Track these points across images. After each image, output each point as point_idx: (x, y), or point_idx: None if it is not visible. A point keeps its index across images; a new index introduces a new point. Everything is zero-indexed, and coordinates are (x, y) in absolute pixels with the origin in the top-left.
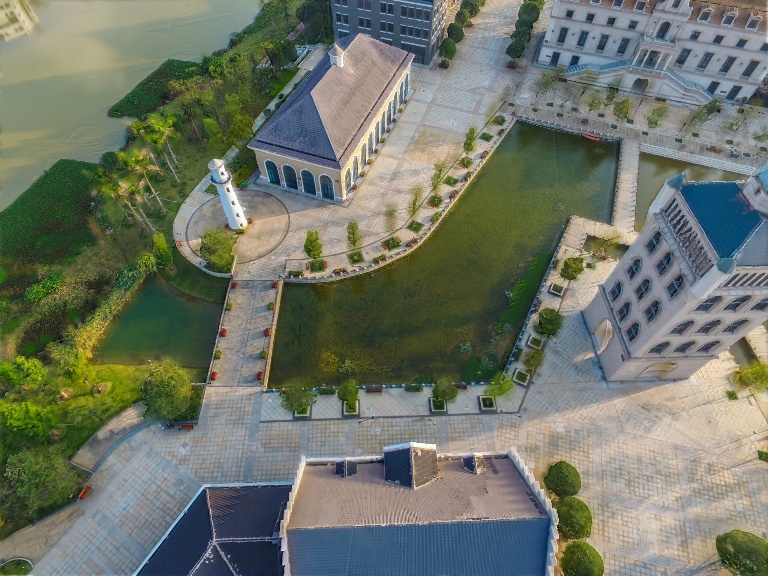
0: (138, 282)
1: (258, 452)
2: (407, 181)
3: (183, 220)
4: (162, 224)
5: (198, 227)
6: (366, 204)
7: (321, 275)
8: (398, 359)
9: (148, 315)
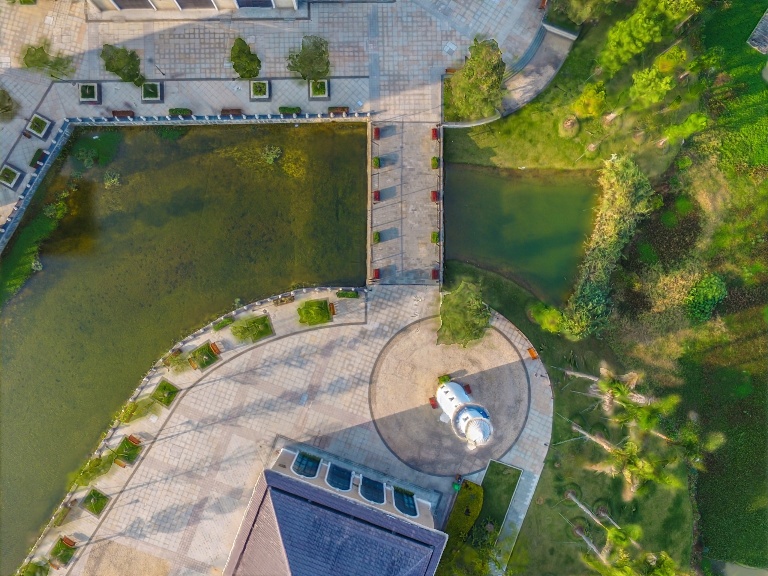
0: (576, 294)
1: (366, 42)
2: (173, 501)
3: (540, 405)
4: (572, 401)
5: (513, 390)
6: (246, 444)
7: (311, 295)
8: (204, 166)
9: (548, 246)
